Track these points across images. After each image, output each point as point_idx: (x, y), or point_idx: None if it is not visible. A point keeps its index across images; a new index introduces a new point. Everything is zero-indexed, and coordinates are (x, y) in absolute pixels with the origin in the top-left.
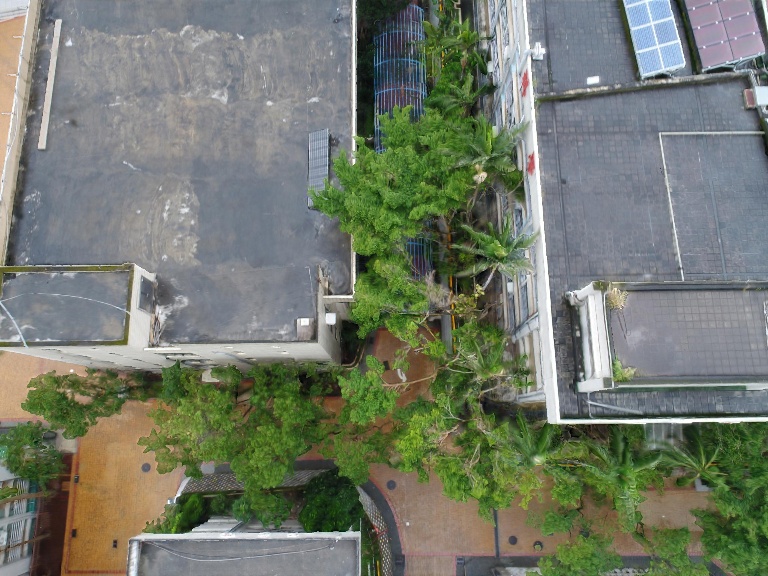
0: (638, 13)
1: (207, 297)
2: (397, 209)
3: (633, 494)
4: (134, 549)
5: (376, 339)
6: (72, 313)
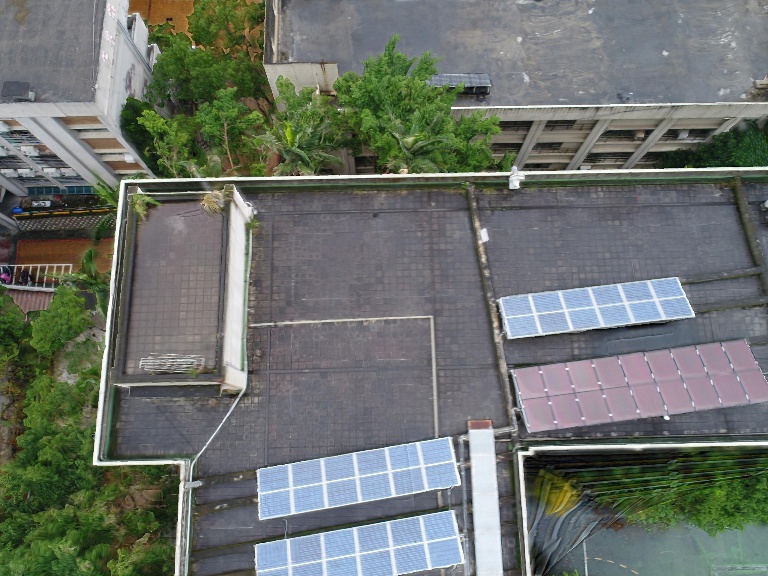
0: (580, 298)
1: None
2: None
3: None
4: None
5: None
6: None
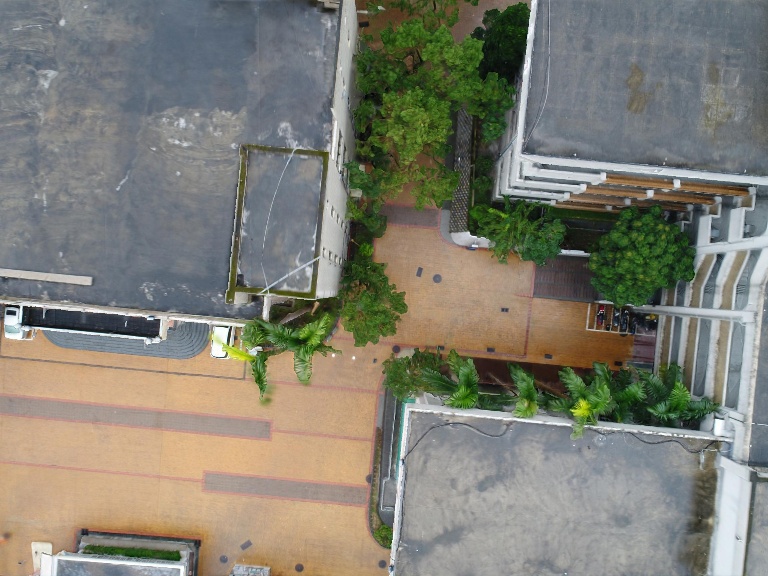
0: None
1: (283, 102)
2: None
3: None
4: None
5: None
6: (288, 213)
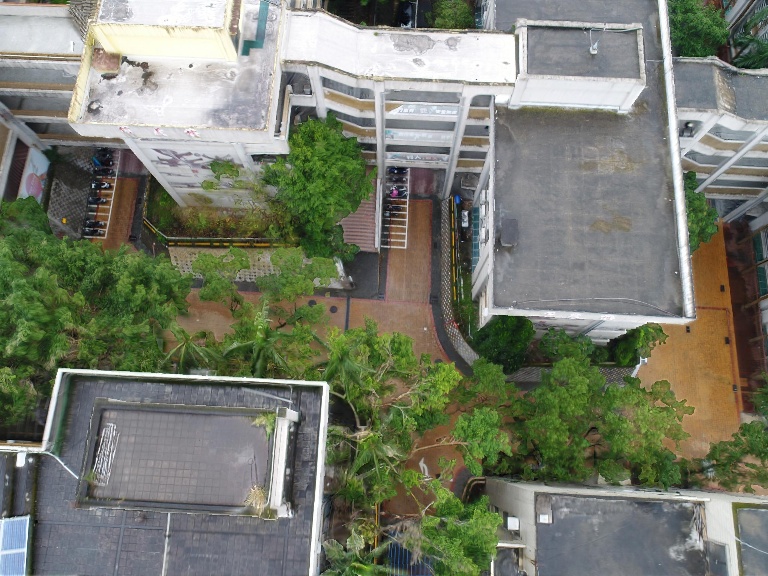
0: None
1: (650, 556)
2: None
3: (262, 321)
4: (690, 311)
5: None
6: None
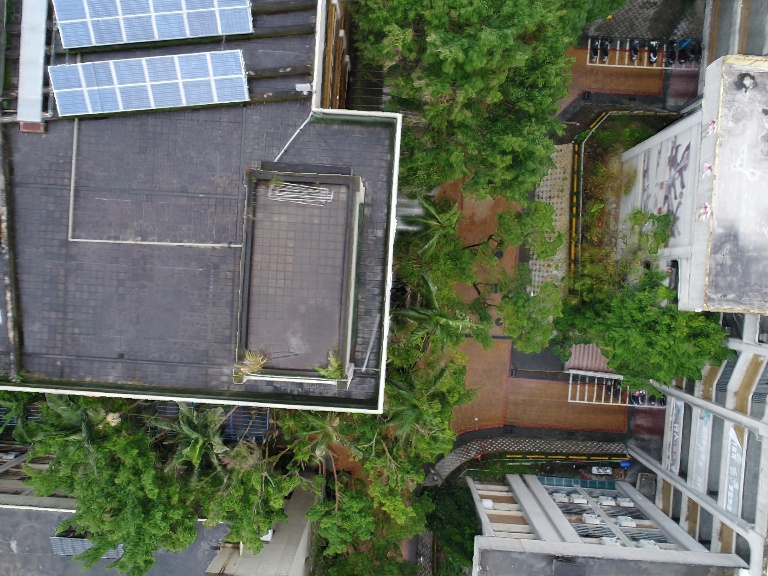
0: None
1: None
2: (145, 502)
3: None
4: None
5: (296, 436)
6: None
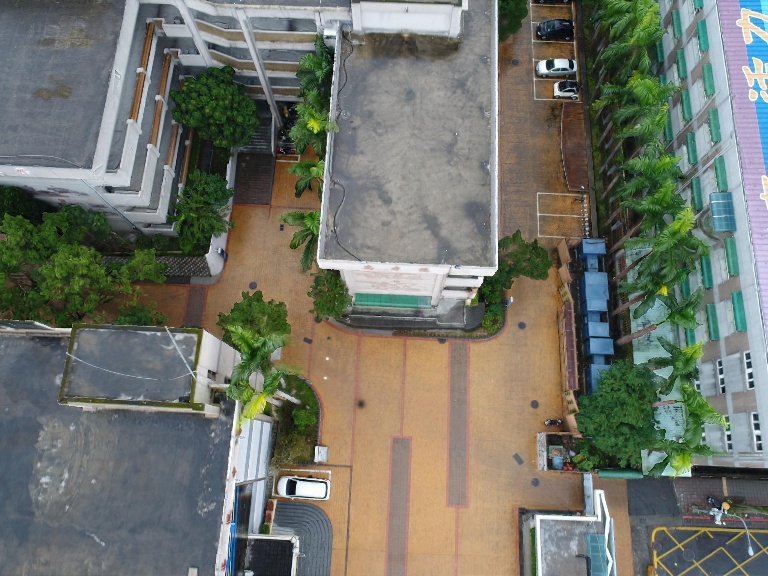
0: None
1: (37, 383)
2: None
3: None
4: None
5: None
6: (125, 358)
